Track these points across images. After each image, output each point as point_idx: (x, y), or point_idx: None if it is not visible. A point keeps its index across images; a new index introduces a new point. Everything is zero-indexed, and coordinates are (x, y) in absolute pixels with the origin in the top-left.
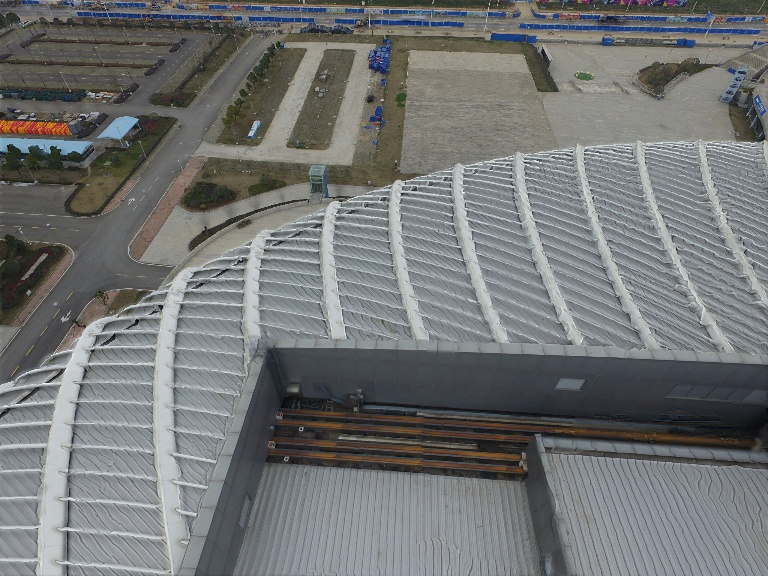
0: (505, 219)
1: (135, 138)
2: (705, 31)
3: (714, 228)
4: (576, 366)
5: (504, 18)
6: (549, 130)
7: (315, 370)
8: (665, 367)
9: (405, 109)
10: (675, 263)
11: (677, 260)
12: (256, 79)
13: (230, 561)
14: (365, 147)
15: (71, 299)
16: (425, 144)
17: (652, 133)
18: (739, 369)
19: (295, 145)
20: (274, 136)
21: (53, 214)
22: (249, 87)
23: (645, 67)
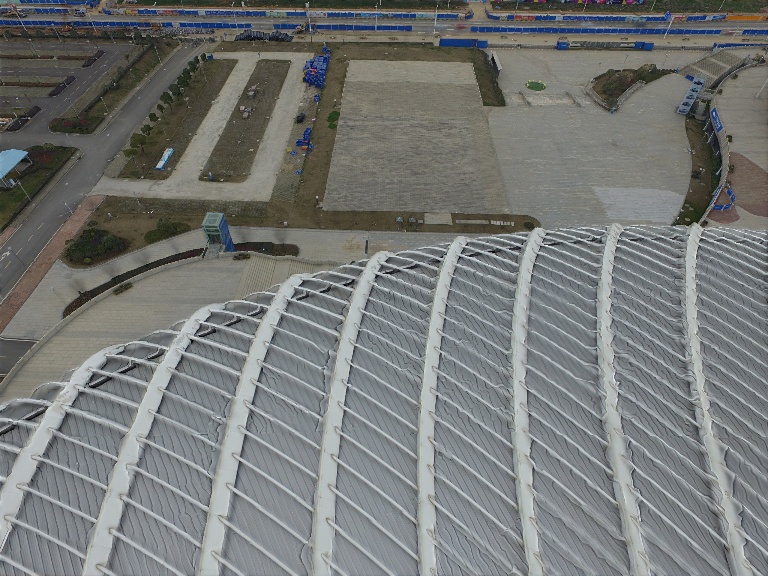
0: (301, 407)
1: (23, 174)
2: (664, 32)
3: (596, 419)
4: None
5: (456, 20)
6: (492, 152)
7: None
8: None
9: (336, 131)
10: (520, 514)
11: (526, 504)
12: (171, 99)
13: None
14: (287, 178)
15: None
16: (354, 173)
17: (603, 153)
18: None
19: (208, 177)
20: (186, 167)
21: None
22: (162, 109)
23: (600, 74)
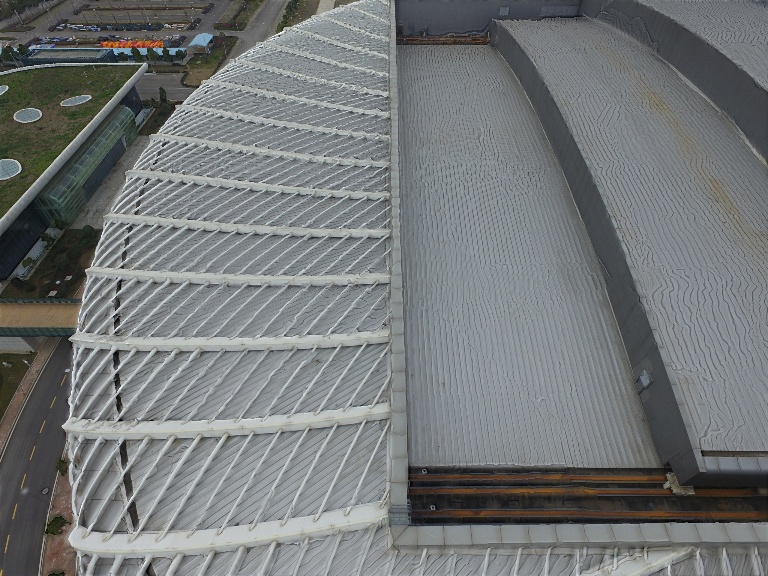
0: None
1: (213, 48)
2: None
3: None
4: None
5: None
6: None
7: (410, 12)
8: None
9: None
10: None
11: None
12: (292, 10)
13: None
14: None
15: None
16: None
17: None
18: None
19: None
20: None
21: (175, 87)
22: (288, 15)
23: None
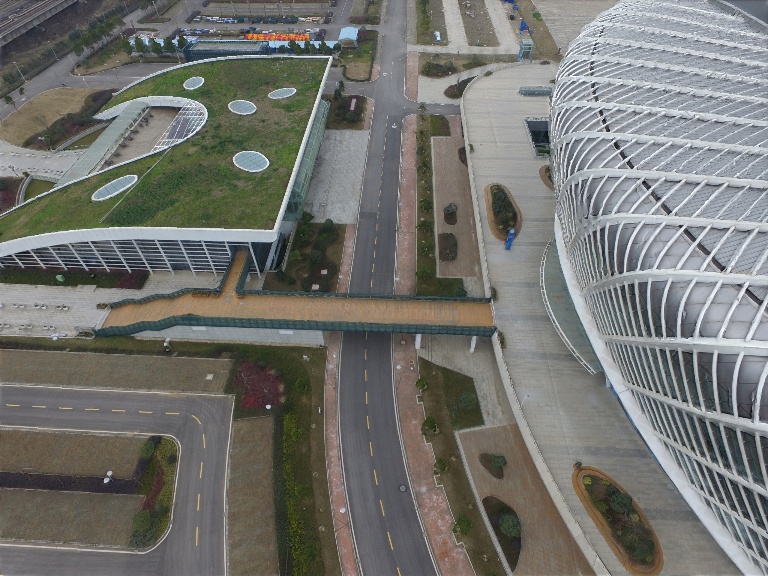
0: None
1: (359, 42)
2: None
3: None
4: None
5: None
6: None
7: None
8: None
9: (544, 22)
10: None
11: None
12: (425, 4)
13: None
14: None
15: (390, 118)
16: None
17: None
18: None
19: (475, 44)
20: (455, 40)
21: None
22: None
23: None
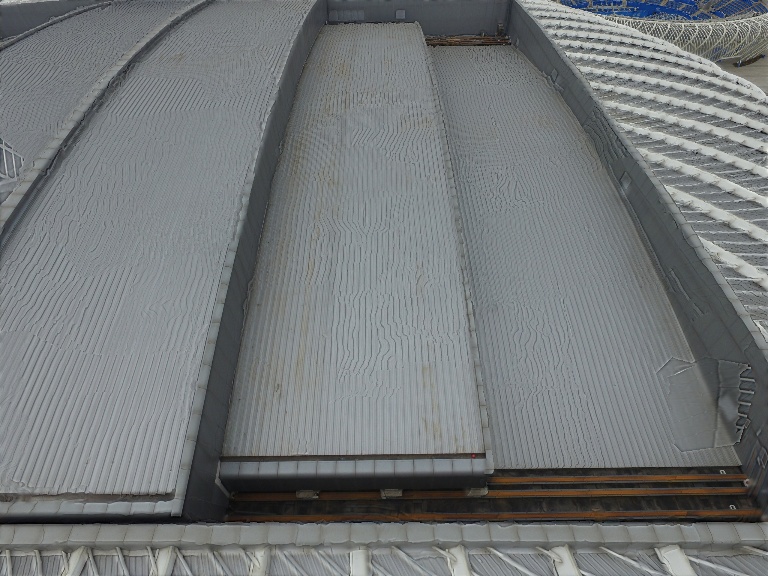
0: None
1: None
2: None
3: None
4: (59, 6)
5: None
6: None
7: None
8: (88, 3)
9: None
10: None
11: None
12: None
13: None
14: None
15: None
16: None
17: None
18: None
19: None
20: None
21: None
22: None
23: None
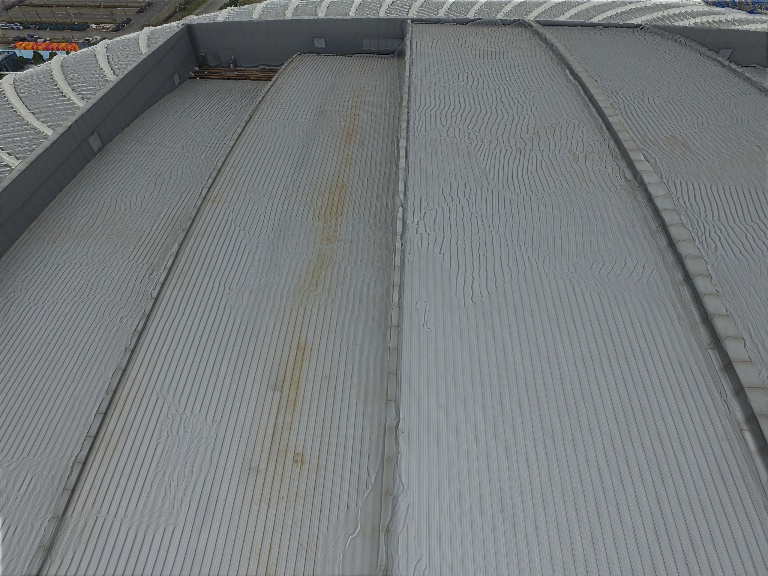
0: (317, 0)
1: None
2: None
3: None
4: (315, 25)
5: None
6: None
7: (210, 40)
8: (350, 23)
9: None
10: None
11: (385, 4)
12: None
13: (169, 83)
14: None
15: None
16: None
17: None
18: (379, 22)
19: None
20: None
21: None
22: None
23: None
